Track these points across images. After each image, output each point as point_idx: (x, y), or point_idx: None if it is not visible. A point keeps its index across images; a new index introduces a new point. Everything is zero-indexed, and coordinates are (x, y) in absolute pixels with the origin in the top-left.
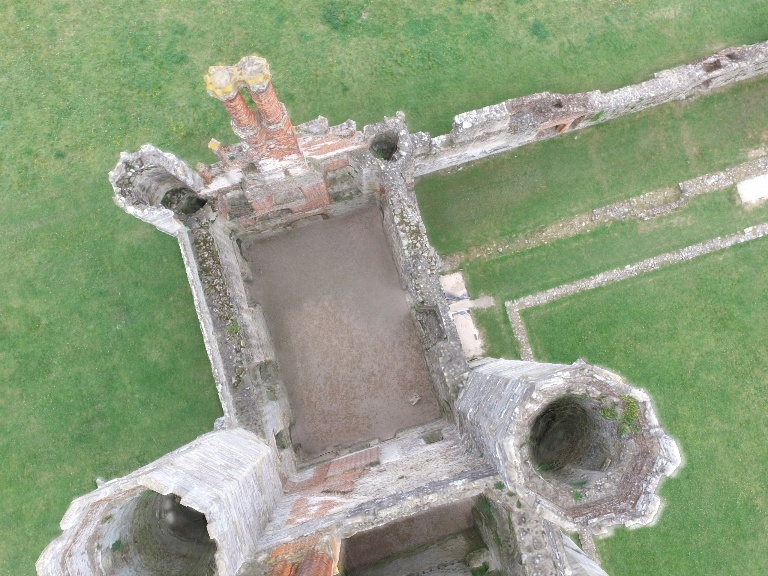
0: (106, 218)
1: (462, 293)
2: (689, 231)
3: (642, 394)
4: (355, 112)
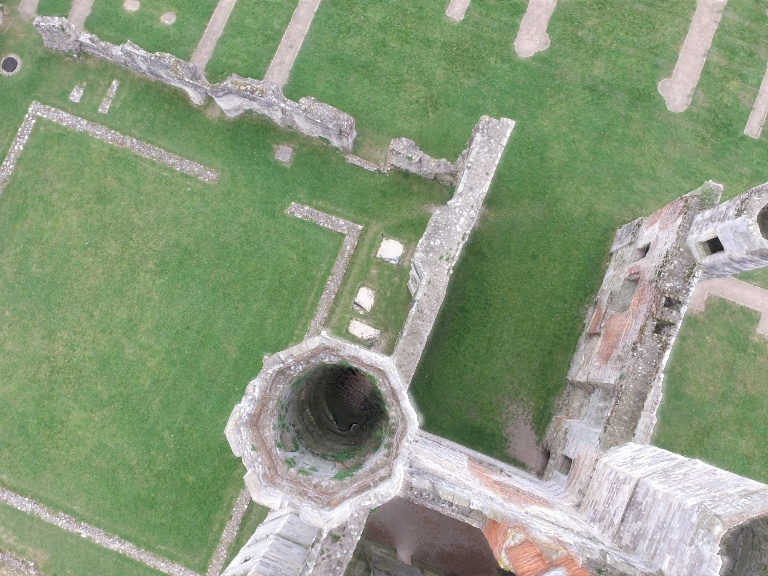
0: None
1: None
2: (8, 523)
3: None
4: None
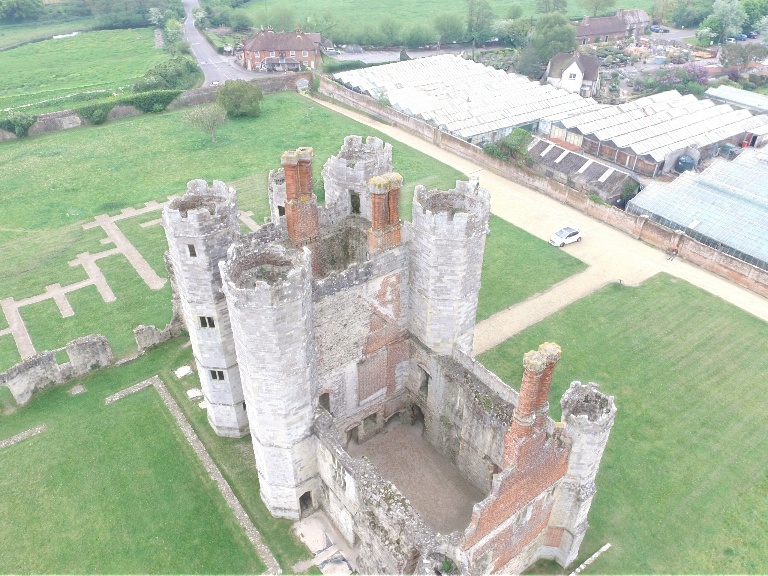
0: (651, 517)
1: (325, 568)
2: None
3: (239, 289)
4: None
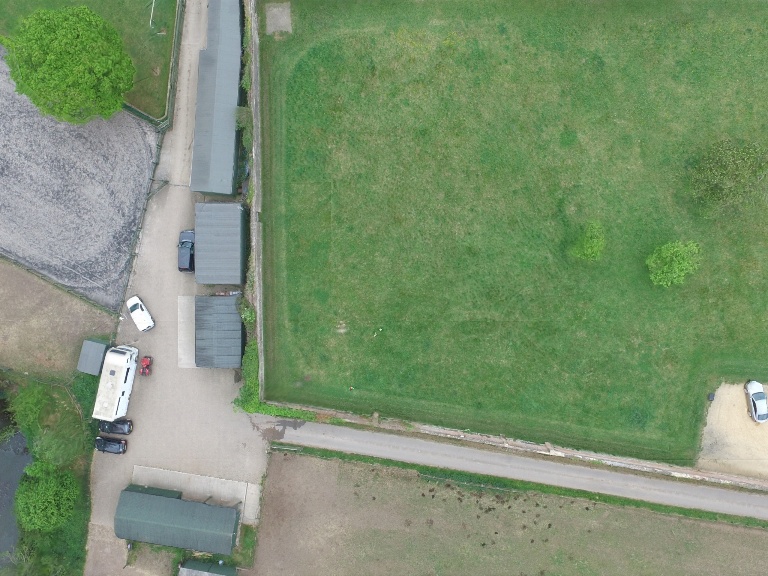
0: None
1: None
2: None
3: None
4: (603, 13)
